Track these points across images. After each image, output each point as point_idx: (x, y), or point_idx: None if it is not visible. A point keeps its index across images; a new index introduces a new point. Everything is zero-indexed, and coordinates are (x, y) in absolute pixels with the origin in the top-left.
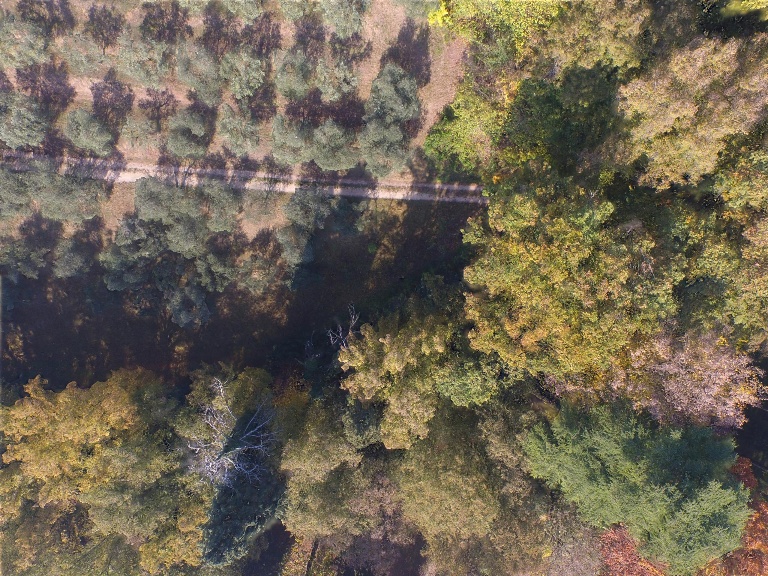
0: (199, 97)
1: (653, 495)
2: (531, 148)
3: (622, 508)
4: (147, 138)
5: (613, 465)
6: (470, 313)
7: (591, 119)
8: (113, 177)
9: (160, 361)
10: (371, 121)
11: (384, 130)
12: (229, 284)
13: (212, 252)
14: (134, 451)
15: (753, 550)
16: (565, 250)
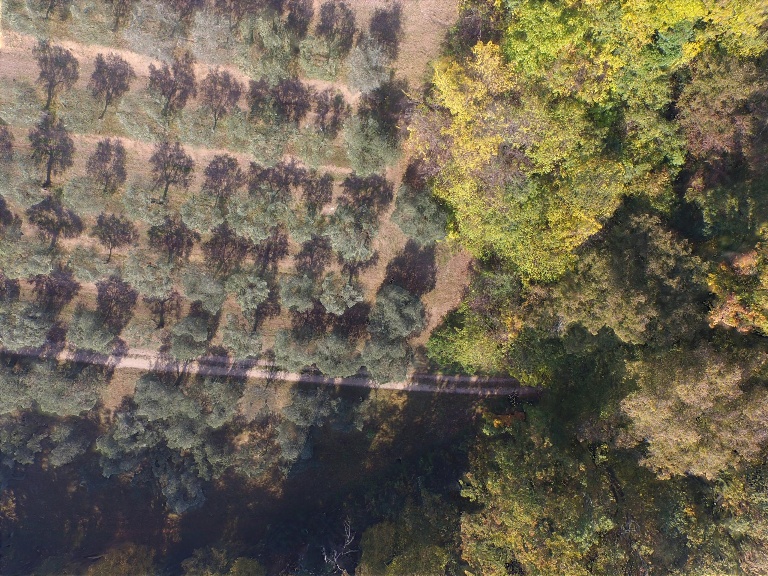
0: (204, 307)
1: None
2: (533, 370)
3: None
4: (150, 341)
5: None
6: (466, 573)
7: (594, 358)
8: (114, 362)
9: (153, 526)
10: (374, 342)
11: (387, 348)
12: None
13: (210, 439)
14: None
15: None
16: (563, 569)
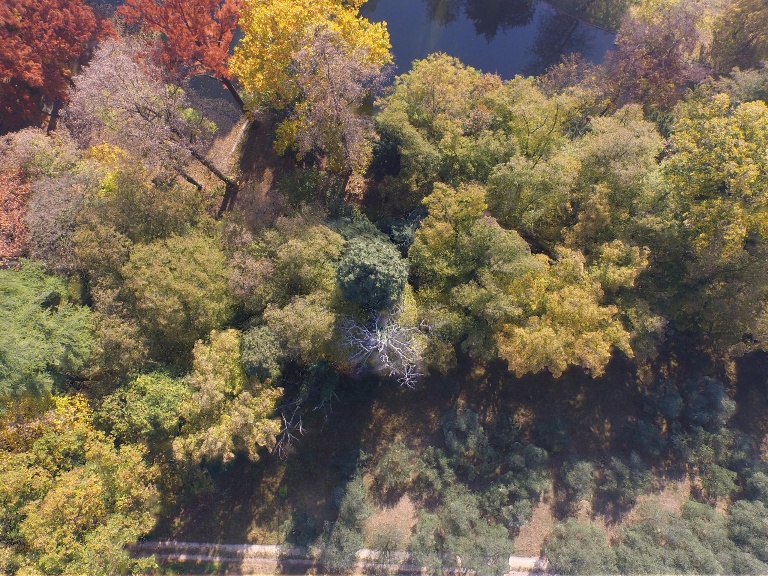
0: None
1: None
2: None
3: None
4: None
5: None
6: (141, 489)
7: None
8: (541, 562)
9: None
10: None
11: None
12: None
13: None
14: None
15: None
16: None
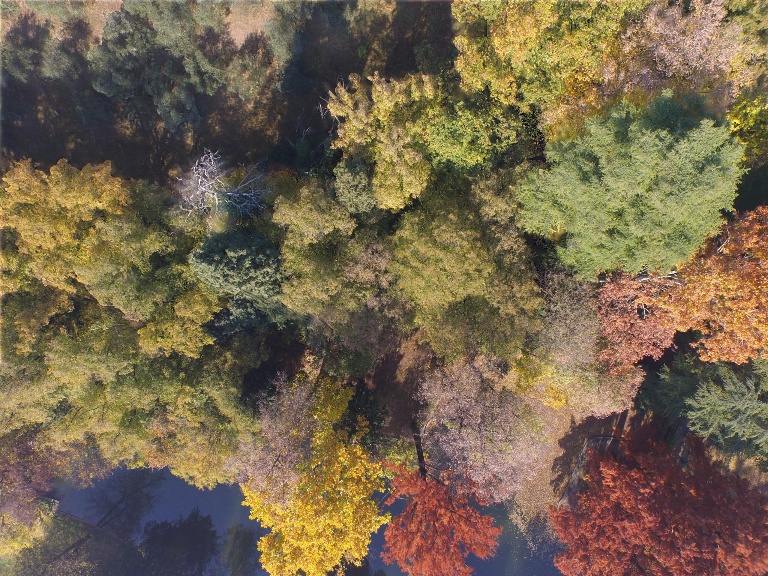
0: None
1: (644, 140)
2: None
3: (614, 173)
4: None
5: (605, 156)
6: (459, 43)
7: None
8: None
9: None
10: None
11: None
12: (219, 98)
13: None
14: (128, 226)
15: (750, 249)
16: None
